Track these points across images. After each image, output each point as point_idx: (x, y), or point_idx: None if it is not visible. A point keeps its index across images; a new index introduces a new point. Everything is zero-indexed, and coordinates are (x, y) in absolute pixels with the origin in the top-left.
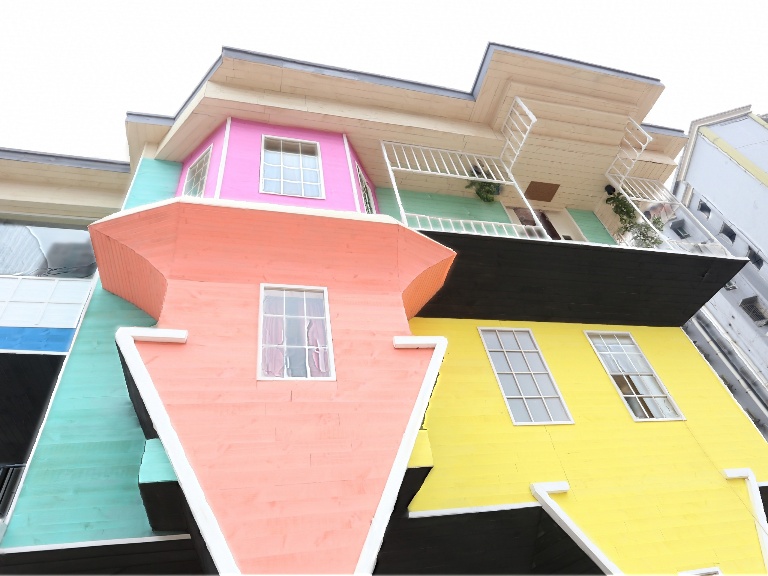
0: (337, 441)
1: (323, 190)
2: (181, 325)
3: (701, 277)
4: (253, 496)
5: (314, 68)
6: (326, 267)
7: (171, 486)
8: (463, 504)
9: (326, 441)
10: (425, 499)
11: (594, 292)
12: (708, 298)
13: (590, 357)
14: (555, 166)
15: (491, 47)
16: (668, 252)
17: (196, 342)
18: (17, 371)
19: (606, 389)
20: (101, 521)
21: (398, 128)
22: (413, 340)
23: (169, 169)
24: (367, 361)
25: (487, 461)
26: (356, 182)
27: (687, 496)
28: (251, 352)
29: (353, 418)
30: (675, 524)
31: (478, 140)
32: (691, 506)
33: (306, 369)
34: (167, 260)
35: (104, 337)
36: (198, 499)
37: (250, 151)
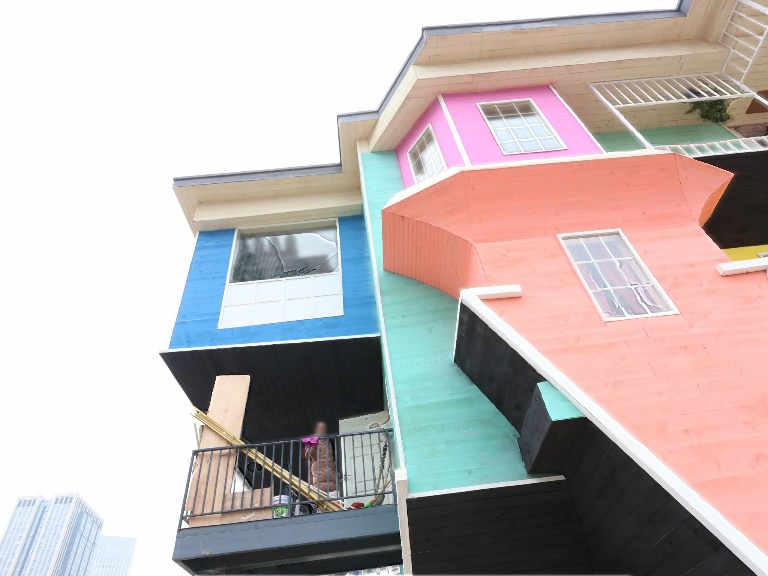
0: (716, 370)
1: (561, 141)
2: (508, 281)
3: None
4: (663, 426)
5: (511, 25)
6: (612, 209)
7: (576, 423)
8: None
9: (704, 371)
10: None
11: None
12: None
13: None
14: None
15: None
16: None
17: (529, 294)
18: (306, 358)
19: None
20: (479, 467)
21: (607, 65)
22: (741, 265)
23: (387, 158)
24: (701, 292)
25: None
26: None
27: None
28: (583, 297)
29: (719, 347)
30: None
31: (696, 57)
32: None
33: (643, 307)
34: (466, 227)
35: (405, 311)
36: (619, 430)
37: (474, 120)
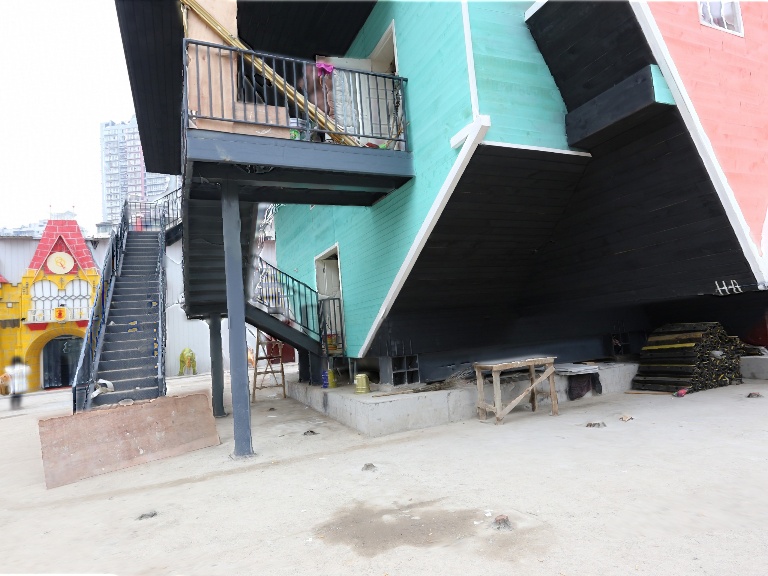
0: (751, 94)
1: None
2: None
3: None
4: (715, 128)
5: None
6: None
7: (663, 109)
8: None
9: (745, 93)
10: None
11: None
12: None
13: None
14: None
15: None
16: None
17: None
18: None
19: None
20: (535, 132)
21: None
22: None
23: None
24: (760, 23)
25: None
26: None
27: None
28: None
29: (758, 76)
30: None
31: None
32: None
33: (723, 20)
34: None
35: None
36: (698, 122)
37: None
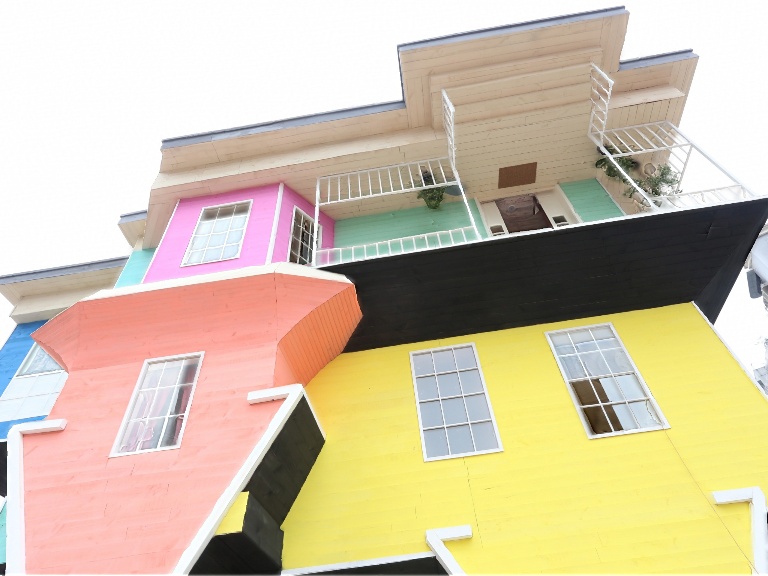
0: (158, 512)
1: (240, 249)
2: (65, 414)
3: (703, 234)
4: (66, 574)
5: (241, 131)
6: (206, 331)
7: None
8: (342, 559)
9: (148, 513)
10: (302, 555)
11: (549, 285)
12: (725, 258)
13: (545, 364)
14: (519, 145)
15: (399, 50)
16: (639, 217)
17: (72, 428)
18: None
19: (558, 402)
20: None
21: (328, 162)
22: (266, 393)
23: (151, 256)
24: (217, 423)
25: (382, 507)
26: (278, 230)
27: (645, 533)
28: (114, 430)
29: (181, 486)
30: (616, 572)
31: (416, 147)
32: (648, 546)
33: (159, 439)
34: (72, 354)
35: None
36: None
37: (186, 227)
